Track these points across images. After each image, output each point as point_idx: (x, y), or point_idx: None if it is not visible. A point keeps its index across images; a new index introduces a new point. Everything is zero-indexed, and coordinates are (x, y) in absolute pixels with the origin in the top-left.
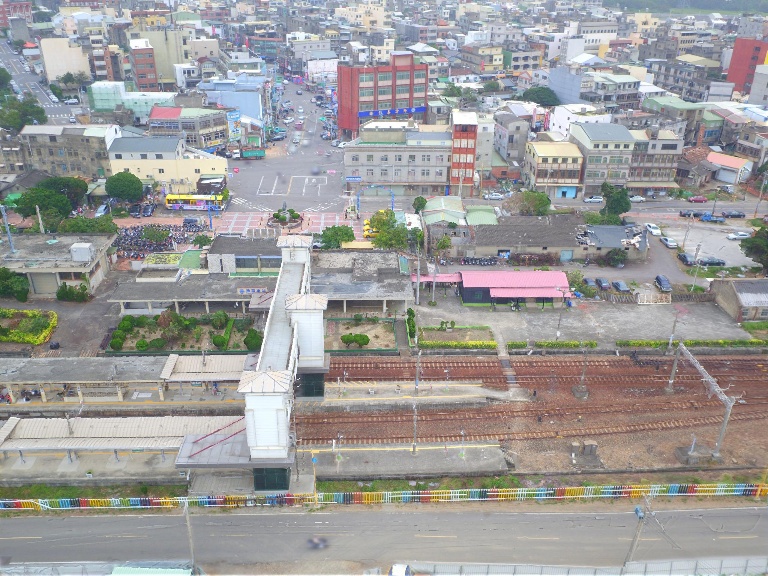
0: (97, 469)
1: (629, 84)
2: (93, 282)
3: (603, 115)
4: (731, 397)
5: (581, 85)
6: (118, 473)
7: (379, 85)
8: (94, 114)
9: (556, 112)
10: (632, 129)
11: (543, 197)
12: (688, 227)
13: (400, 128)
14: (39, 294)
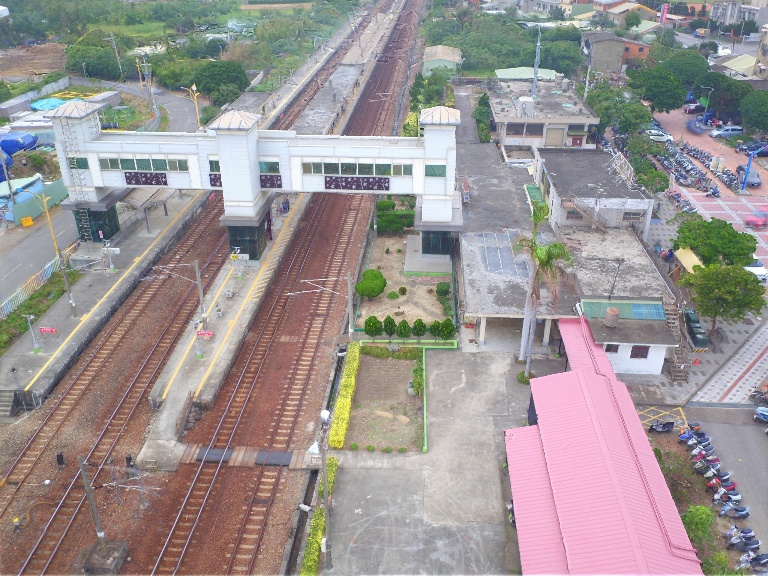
0: None
1: None
2: (514, 143)
3: None
4: None
5: None
6: None
7: None
8: None
9: None
10: None
11: None
12: None
13: None
14: (496, 136)
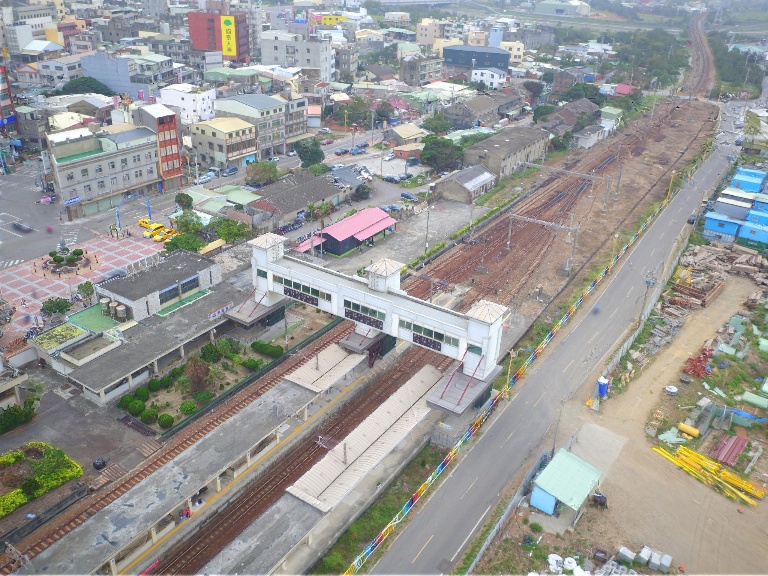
0: (372, 481)
1: (165, 62)
2: None
3: (210, 90)
4: (578, 225)
5: (128, 69)
6: (389, 471)
7: None
8: None
9: (163, 95)
10: (270, 95)
11: (273, 164)
12: (382, 156)
13: (91, 135)
14: None
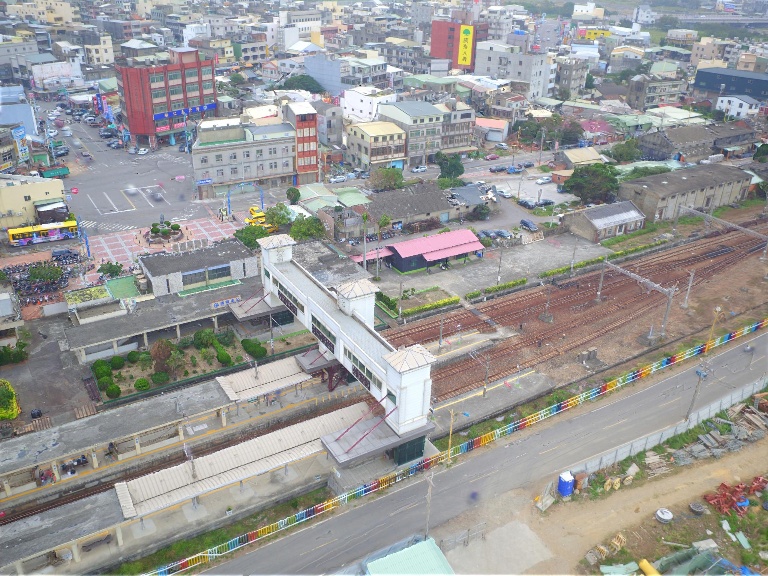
0: (229, 505)
1: (378, 66)
2: None
3: (390, 95)
4: (673, 287)
5: (340, 70)
6: (254, 500)
7: (170, 85)
8: None
9: (346, 96)
10: (434, 104)
11: (399, 171)
12: (521, 178)
13: (237, 125)
14: None
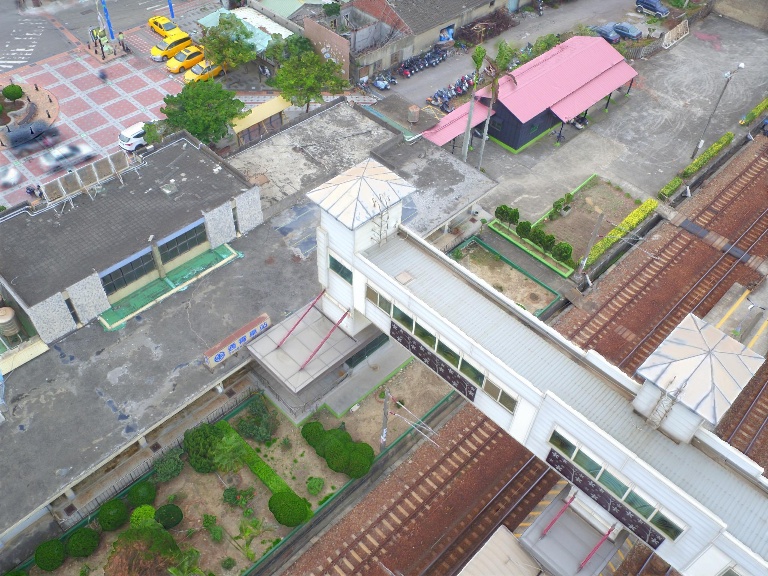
0: None
1: None
2: None
3: None
4: None
5: None
6: None
7: None
8: None
9: None
10: None
11: None
12: None
13: None
14: None
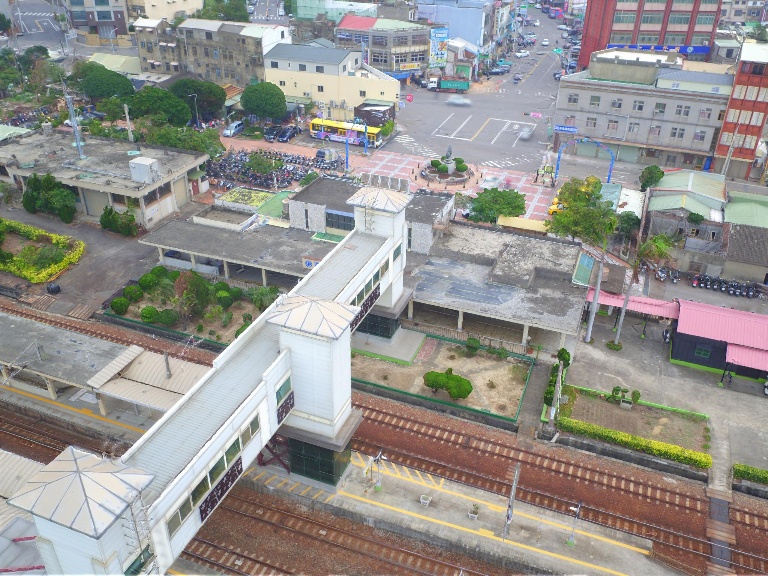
0: None
1: None
2: (153, 212)
3: None
4: None
5: None
6: None
7: (645, 9)
8: (293, 23)
9: None
10: None
11: None
12: None
13: (652, 62)
14: (91, 216)
